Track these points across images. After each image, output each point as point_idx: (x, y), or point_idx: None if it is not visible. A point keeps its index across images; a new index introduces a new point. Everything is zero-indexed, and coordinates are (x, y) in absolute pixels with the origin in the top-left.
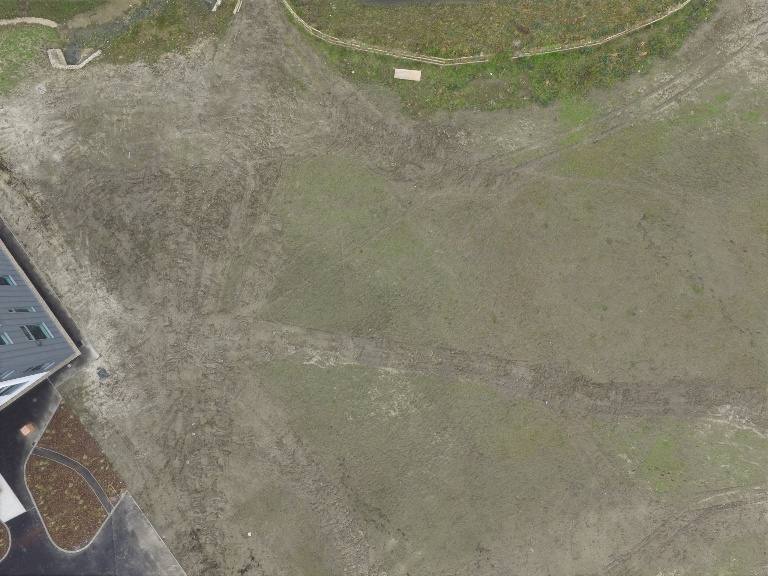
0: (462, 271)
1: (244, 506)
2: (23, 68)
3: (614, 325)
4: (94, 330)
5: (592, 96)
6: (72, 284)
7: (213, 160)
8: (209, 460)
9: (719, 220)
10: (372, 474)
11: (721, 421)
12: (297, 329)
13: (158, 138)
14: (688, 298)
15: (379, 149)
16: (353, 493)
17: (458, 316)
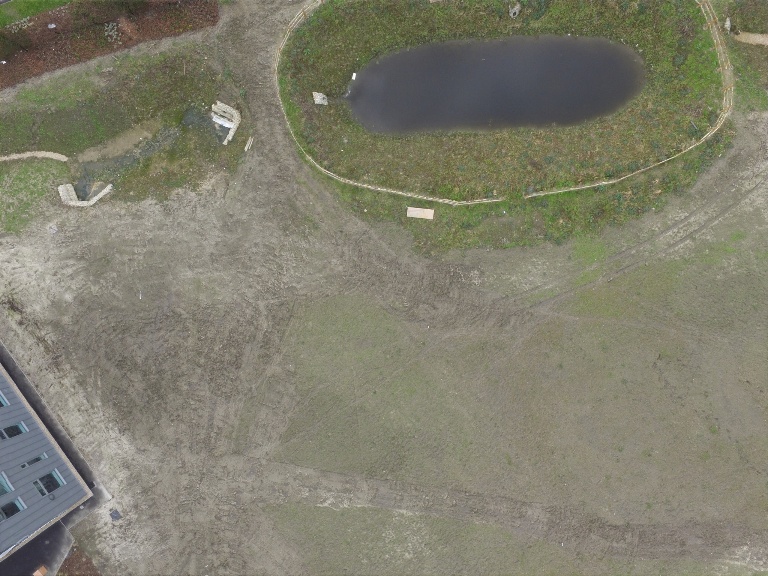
0: (476, 412)
1: None
2: (34, 207)
3: (630, 466)
4: (106, 471)
5: (606, 234)
6: (84, 425)
7: (225, 300)
8: None
9: (735, 360)
10: None
11: (738, 563)
12: (311, 471)
13: (170, 277)
14: (704, 439)
15: (392, 289)
16: None
17: (473, 458)
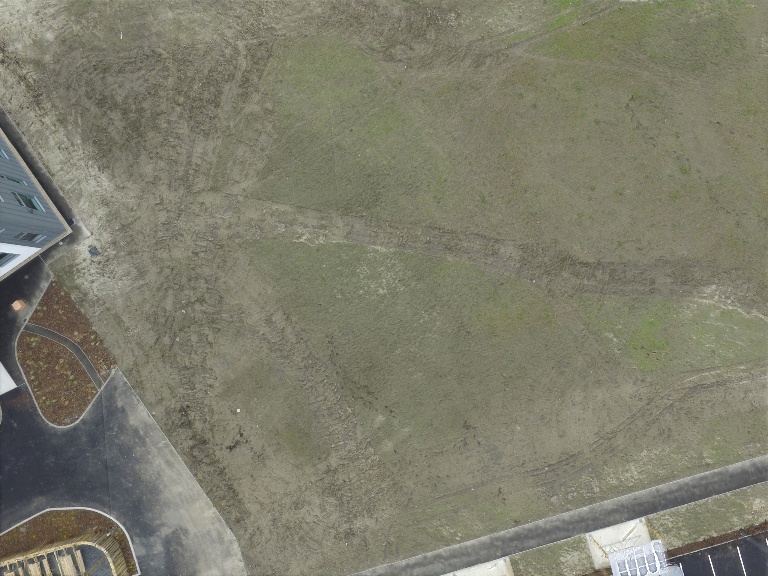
0: (451, 151)
1: (233, 383)
2: None
3: (601, 205)
4: (86, 208)
5: None
6: (64, 162)
7: (205, 40)
8: (199, 337)
9: (706, 102)
10: (360, 352)
11: (707, 301)
12: (287, 207)
13: (150, 18)
14: (675, 179)
15: (370, 30)
16: (341, 370)
17: (447, 195)
